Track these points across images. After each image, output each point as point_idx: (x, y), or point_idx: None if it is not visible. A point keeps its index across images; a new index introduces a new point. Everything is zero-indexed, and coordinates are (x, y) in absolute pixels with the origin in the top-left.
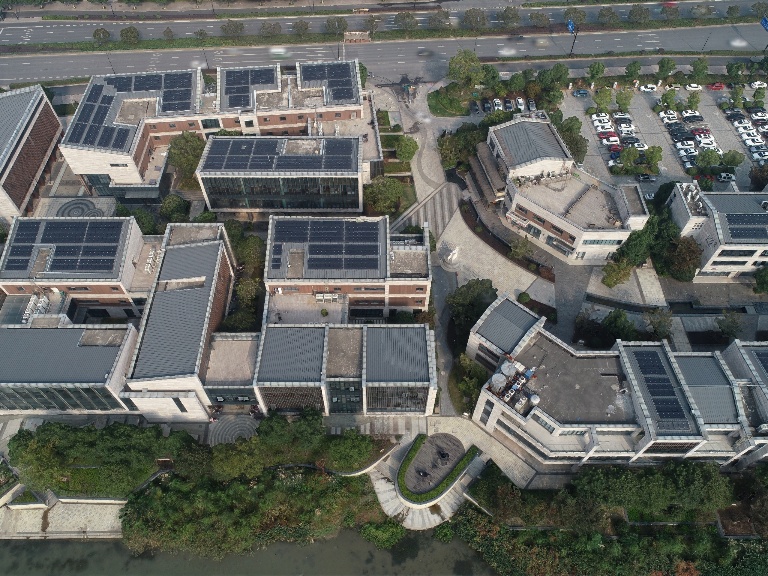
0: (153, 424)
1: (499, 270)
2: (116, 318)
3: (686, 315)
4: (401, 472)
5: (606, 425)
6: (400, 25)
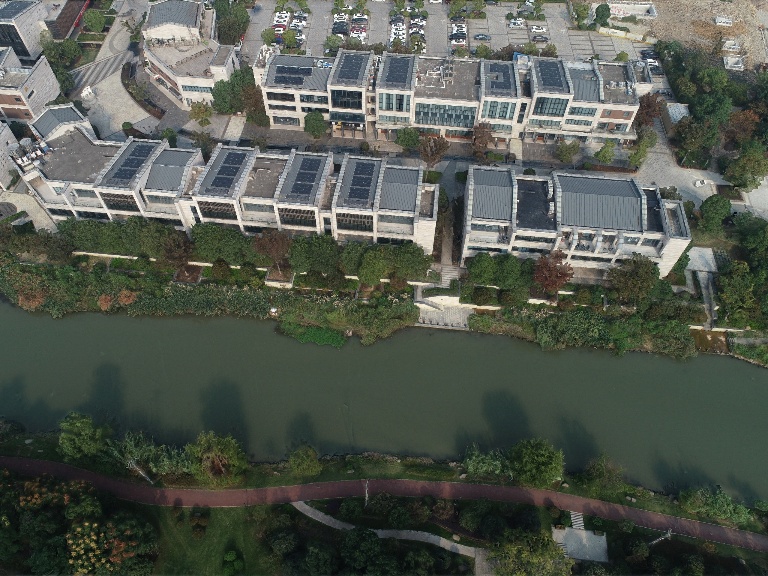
0: None
1: (124, 109)
2: None
3: None
4: None
5: (78, 182)
6: None
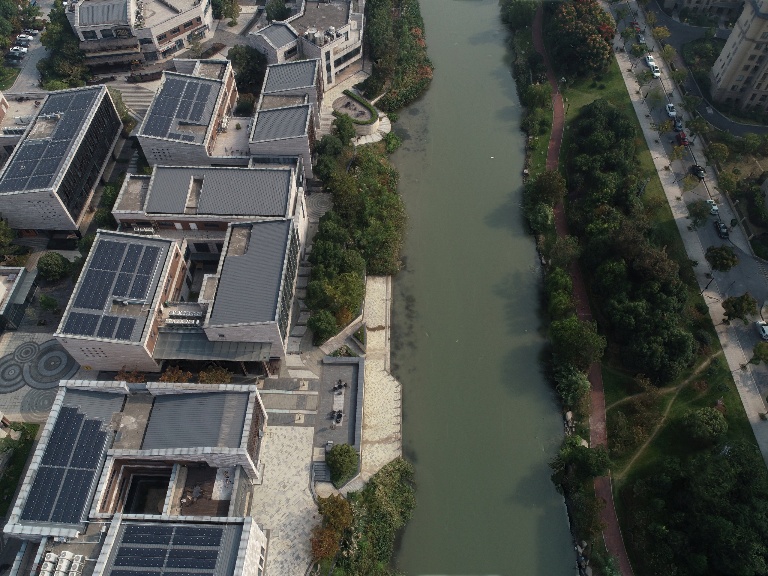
0: (305, 257)
1: None
2: (187, 301)
3: (267, 0)
4: (358, 122)
5: (350, 9)
6: None
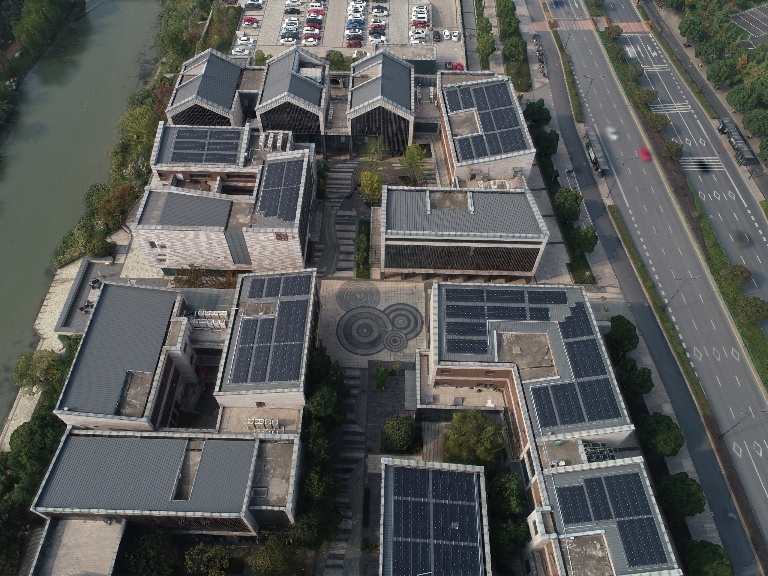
0: None
1: None
2: None
3: None
4: None
5: None
6: None
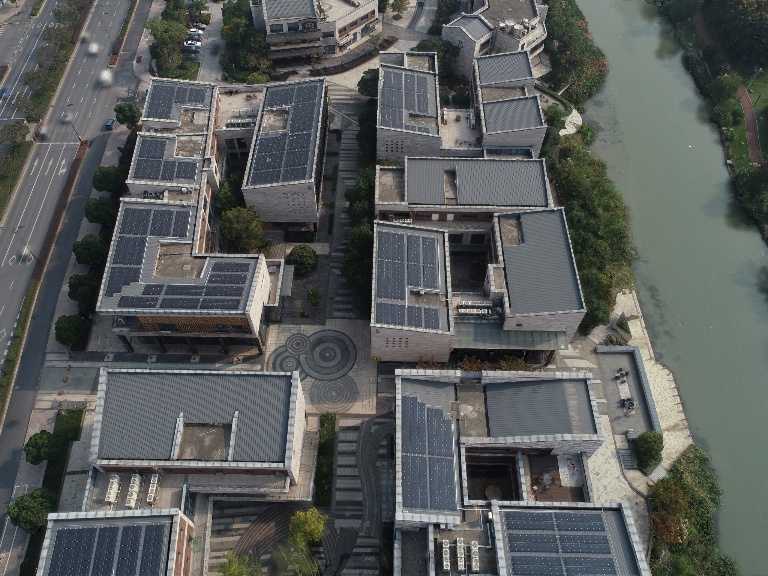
0: None
1: None
2: None
3: None
4: None
5: (535, 1)
6: (43, 85)
